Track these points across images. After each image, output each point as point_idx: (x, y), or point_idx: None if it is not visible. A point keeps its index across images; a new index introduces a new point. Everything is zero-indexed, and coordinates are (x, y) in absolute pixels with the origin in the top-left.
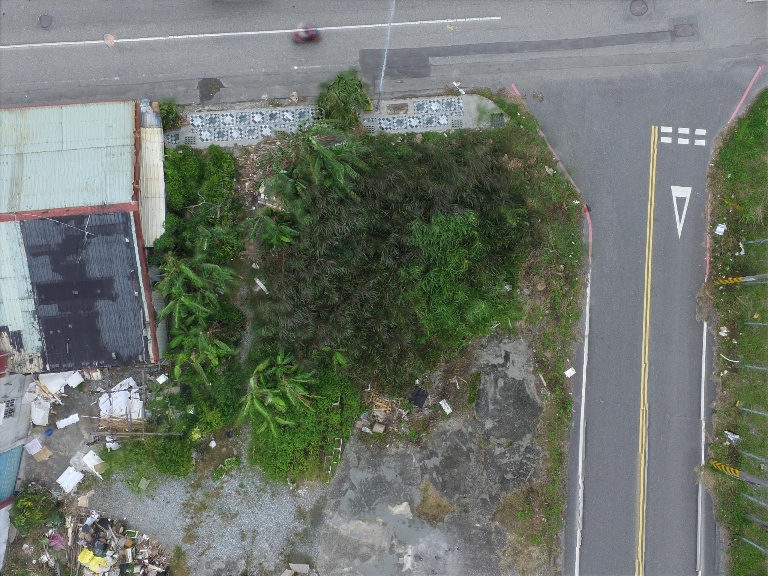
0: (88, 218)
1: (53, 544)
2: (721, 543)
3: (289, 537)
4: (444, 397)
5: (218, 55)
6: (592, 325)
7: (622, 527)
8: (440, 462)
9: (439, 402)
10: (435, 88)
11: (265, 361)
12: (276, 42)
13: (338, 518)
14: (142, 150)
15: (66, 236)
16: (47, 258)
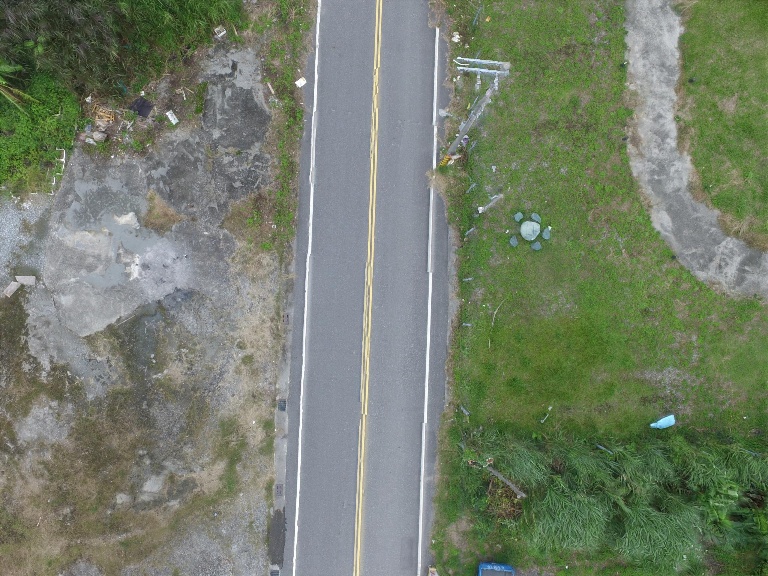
0: None
1: None
2: (454, 246)
3: (15, 250)
4: (171, 108)
5: None
6: (323, 35)
7: (353, 232)
8: (167, 172)
9: (166, 113)
10: None
11: None
12: None
13: (64, 230)
14: None
15: None
16: None
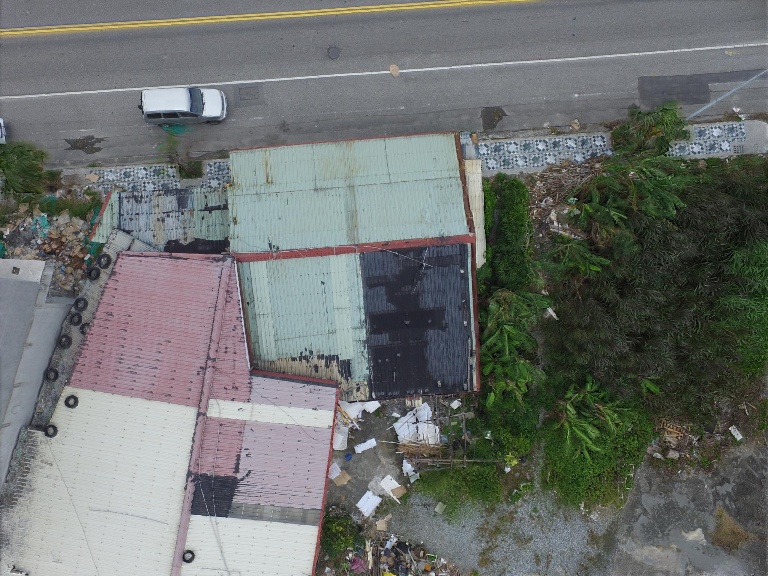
0: (426, 250)
1: (355, 567)
2: None
3: (583, 562)
4: (733, 423)
5: (501, 84)
6: None
7: None
8: (732, 488)
9: (728, 428)
10: (715, 114)
11: (570, 388)
12: (557, 70)
13: (631, 544)
14: (467, 182)
15: (403, 267)
16: (383, 289)
